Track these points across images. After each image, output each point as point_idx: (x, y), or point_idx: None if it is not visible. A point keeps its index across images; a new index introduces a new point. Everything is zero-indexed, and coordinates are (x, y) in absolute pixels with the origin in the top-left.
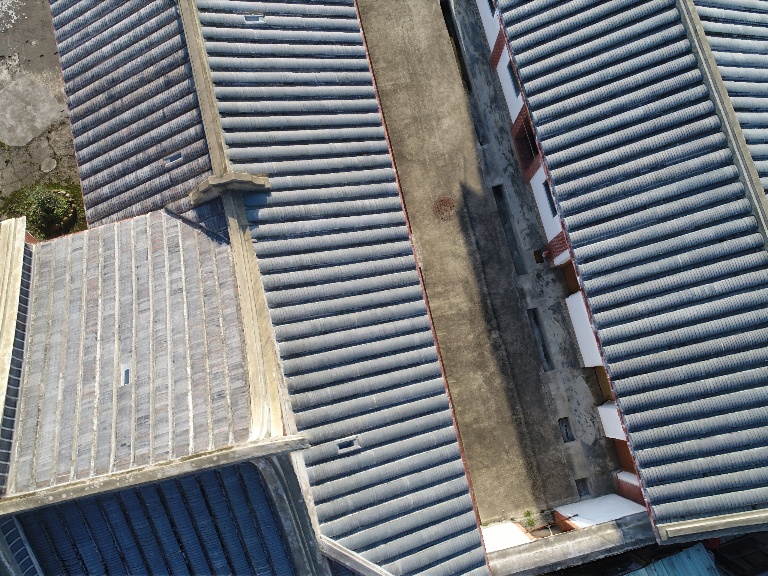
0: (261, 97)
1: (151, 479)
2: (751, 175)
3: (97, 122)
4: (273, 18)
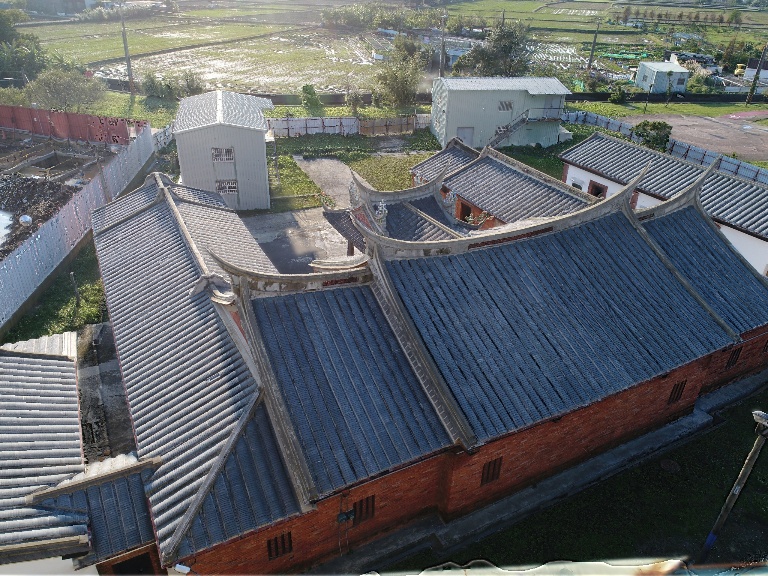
0: None
1: (670, 201)
2: (762, 185)
3: (522, 216)
4: None
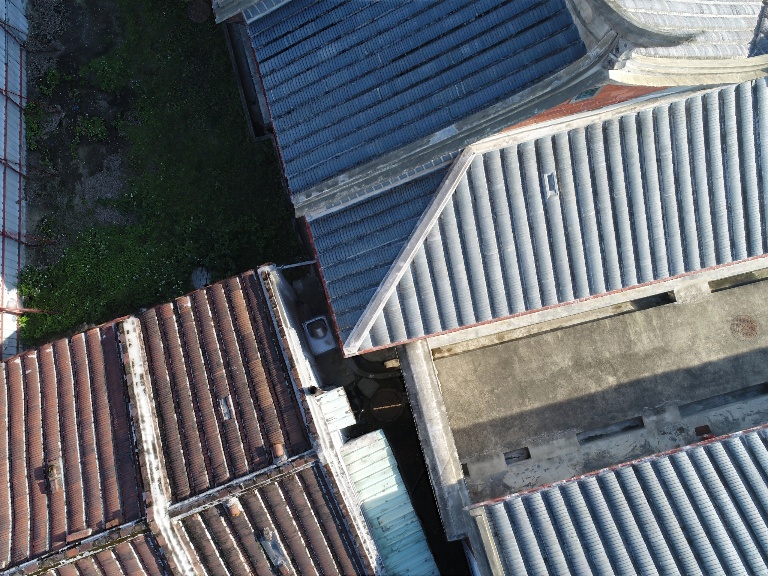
0: None
1: None
2: None
3: None
4: None
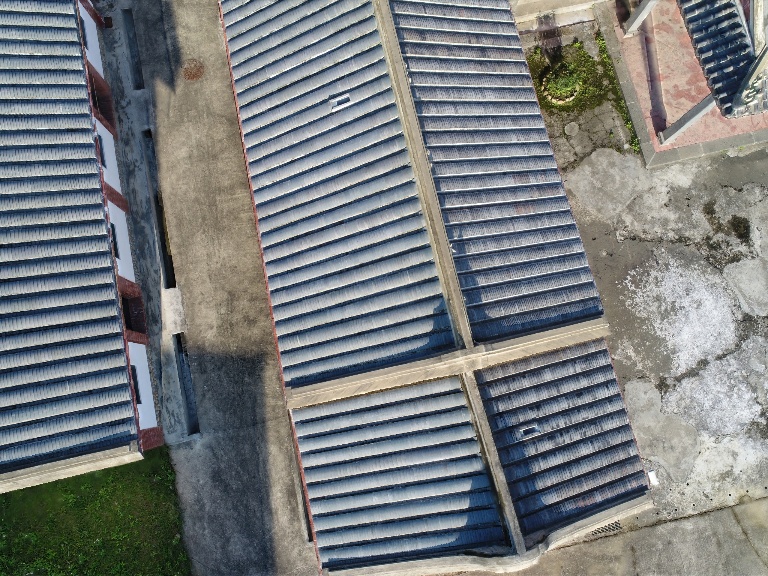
0: (334, 21)
1: None
2: None
3: (495, 37)
4: (324, 111)
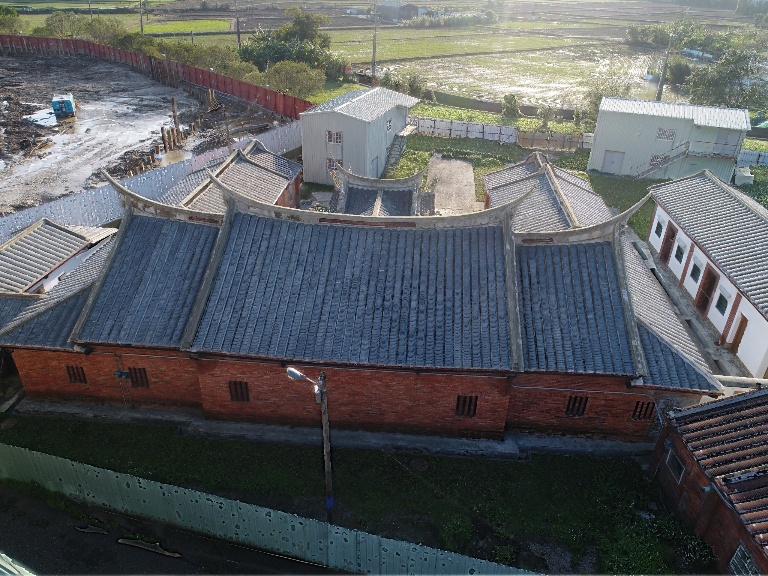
0: None
1: (575, 230)
2: None
3: None
4: None
